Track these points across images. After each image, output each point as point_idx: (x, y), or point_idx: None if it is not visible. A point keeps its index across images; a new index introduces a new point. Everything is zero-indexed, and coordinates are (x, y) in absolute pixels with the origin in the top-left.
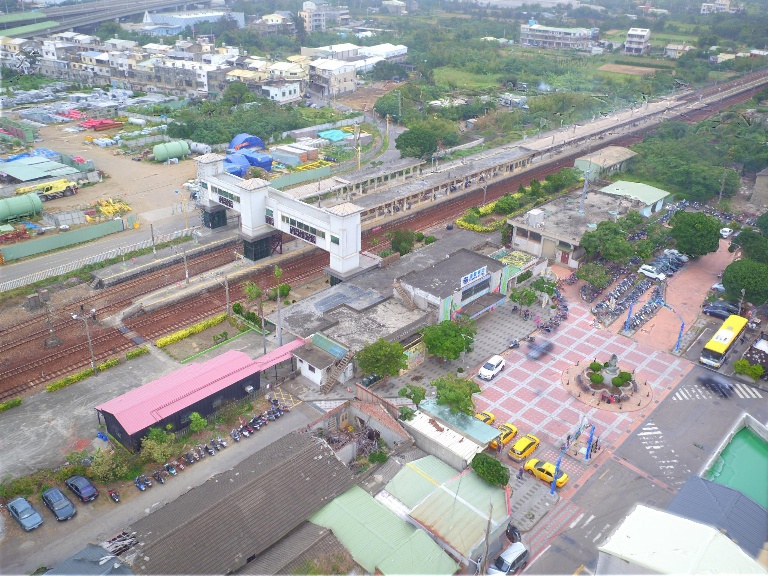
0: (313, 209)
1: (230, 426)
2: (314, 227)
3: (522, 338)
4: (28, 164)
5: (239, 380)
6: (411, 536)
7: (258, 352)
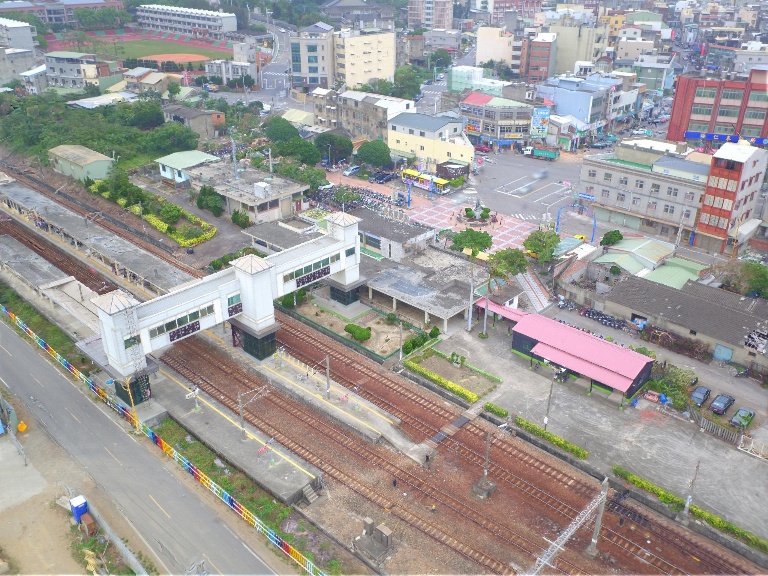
0: (292, 251)
1: None
2: (327, 257)
3: None
4: None
5: None
6: (673, 262)
7: (472, 341)
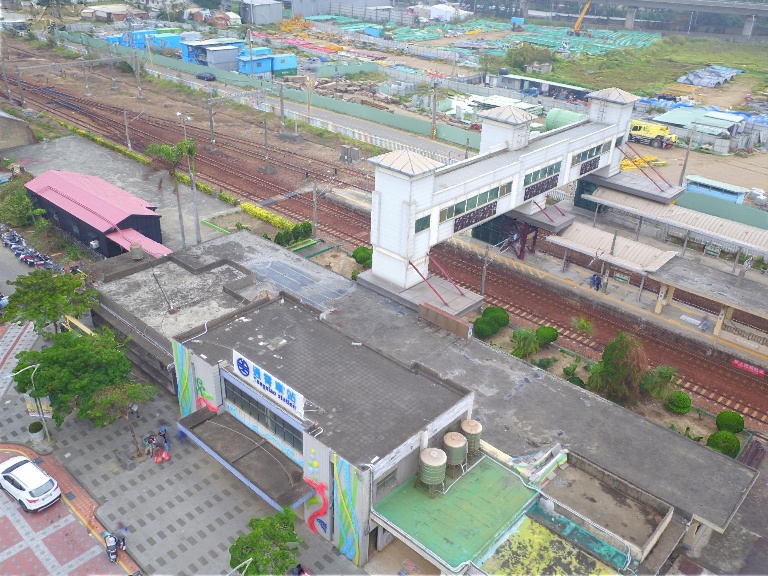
0: None
1: (50, 250)
2: None
3: (152, 575)
4: (706, 115)
5: (87, 222)
6: None
7: None
